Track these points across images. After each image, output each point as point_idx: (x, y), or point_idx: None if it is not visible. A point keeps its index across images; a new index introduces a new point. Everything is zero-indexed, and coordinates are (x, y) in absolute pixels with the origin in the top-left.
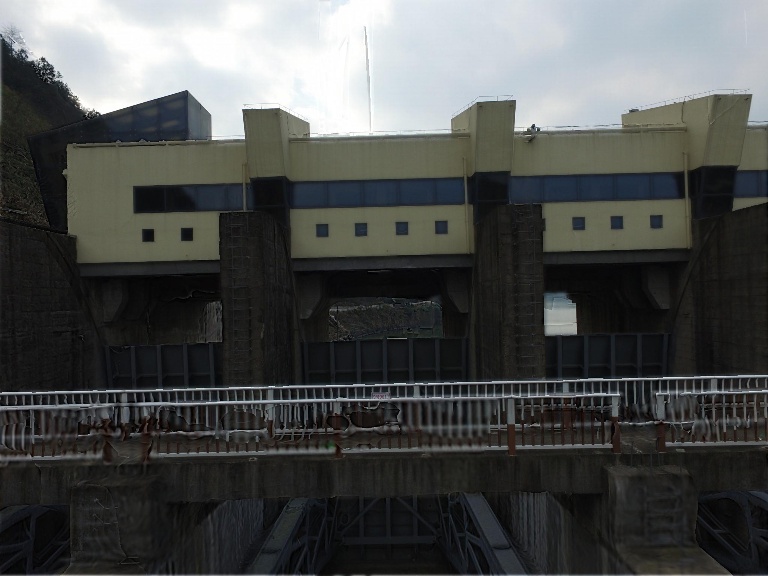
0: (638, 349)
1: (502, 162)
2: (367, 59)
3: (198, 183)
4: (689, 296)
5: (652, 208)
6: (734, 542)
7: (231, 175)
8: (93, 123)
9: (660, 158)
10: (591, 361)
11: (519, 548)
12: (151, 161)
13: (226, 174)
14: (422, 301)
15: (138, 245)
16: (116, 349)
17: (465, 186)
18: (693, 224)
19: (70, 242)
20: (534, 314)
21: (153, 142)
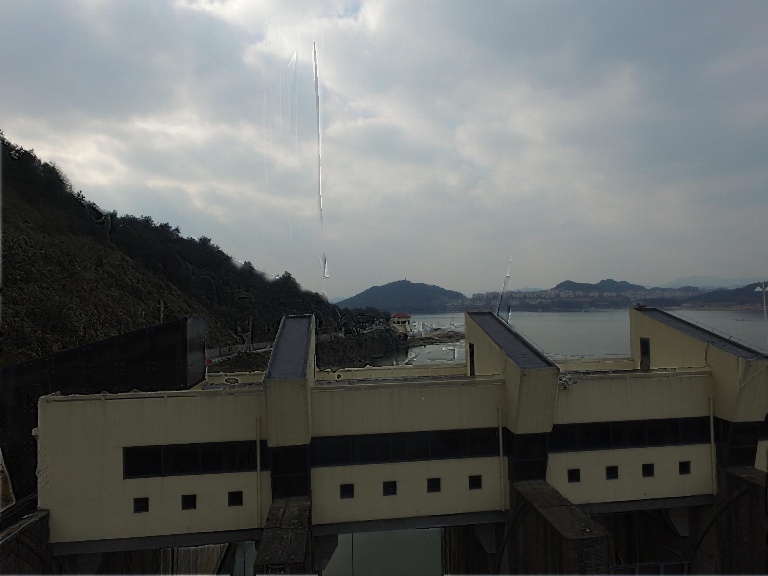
0: None
1: (542, 424)
2: (316, 75)
3: (203, 441)
4: (713, 539)
5: (681, 454)
6: None
7: (242, 431)
8: (68, 354)
9: (687, 403)
10: None
11: None
12: (145, 416)
13: (236, 429)
14: (372, 326)
15: (128, 517)
16: None
17: (500, 438)
18: (719, 471)
19: (42, 525)
20: None
21: (148, 393)
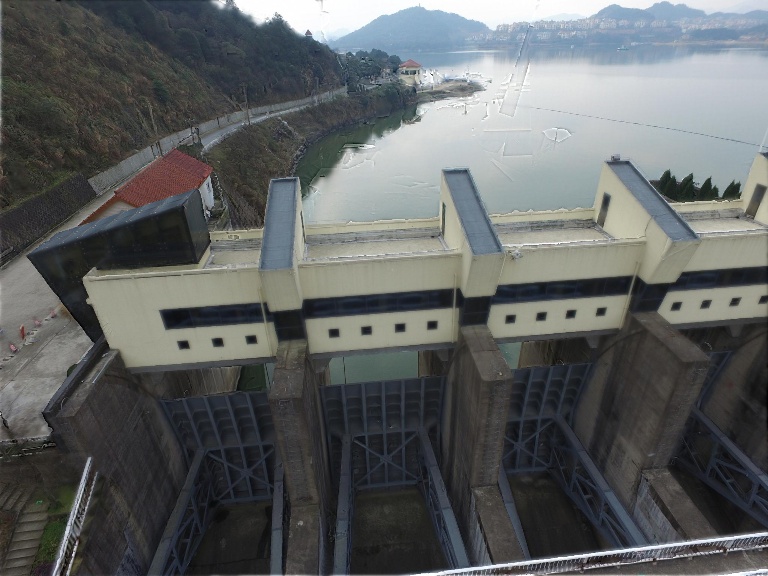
0: (568, 374)
1: (487, 291)
2: None
3: (219, 304)
4: (611, 354)
5: (601, 303)
6: (593, 503)
7: (248, 297)
8: (91, 238)
9: (617, 266)
10: (533, 379)
11: (474, 563)
12: (170, 289)
13: (243, 296)
14: (377, 79)
15: (176, 352)
16: (165, 393)
17: (454, 297)
18: (628, 314)
19: (117, 360)
20: (498, 437)
21: (167, 272)
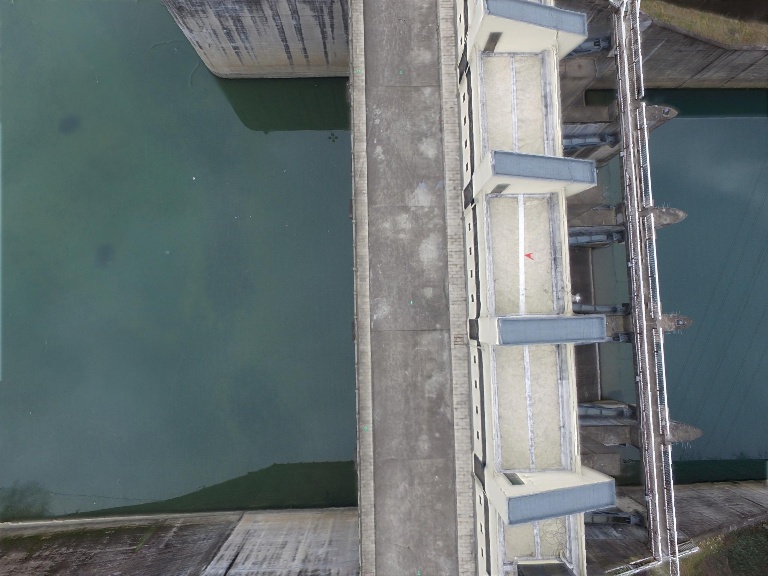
0: None
1: None
2: None
3: None
4: None
5: None
6: None
7: None
8: None
9: None
10: None
11: None
12: None
13: None
14: None
15: None
16: None
17: None
18: None
19: None
20: None
21: None
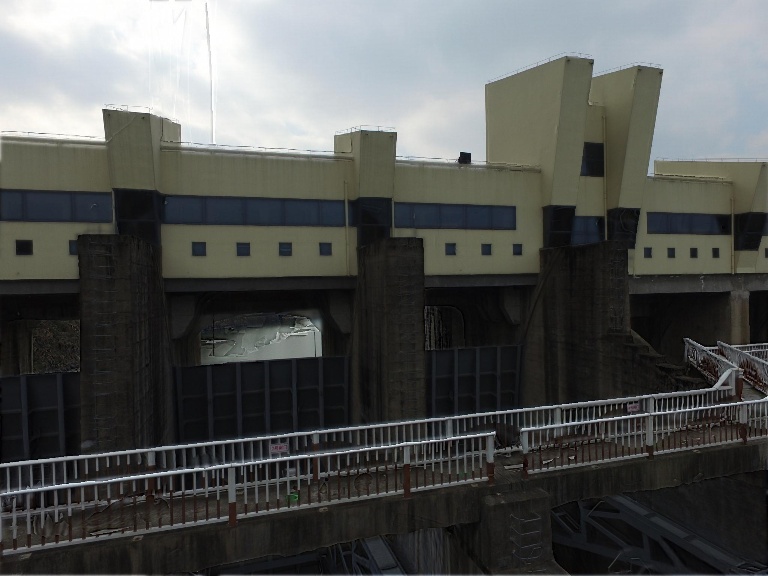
0: None
1: None
2: (208, 37)
3: None
4: None
5: (72, 232)
6: None
7: None
8: None
9: (84, 175)
10: (42, 404)
11: None
12: None
13: None
14: None
15: None
16: None
17: None
18: None
19: None
20: None
21: None
